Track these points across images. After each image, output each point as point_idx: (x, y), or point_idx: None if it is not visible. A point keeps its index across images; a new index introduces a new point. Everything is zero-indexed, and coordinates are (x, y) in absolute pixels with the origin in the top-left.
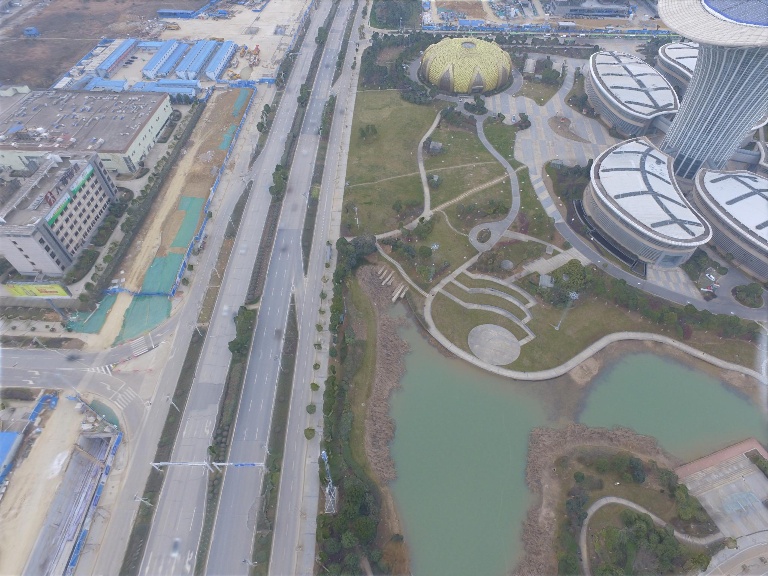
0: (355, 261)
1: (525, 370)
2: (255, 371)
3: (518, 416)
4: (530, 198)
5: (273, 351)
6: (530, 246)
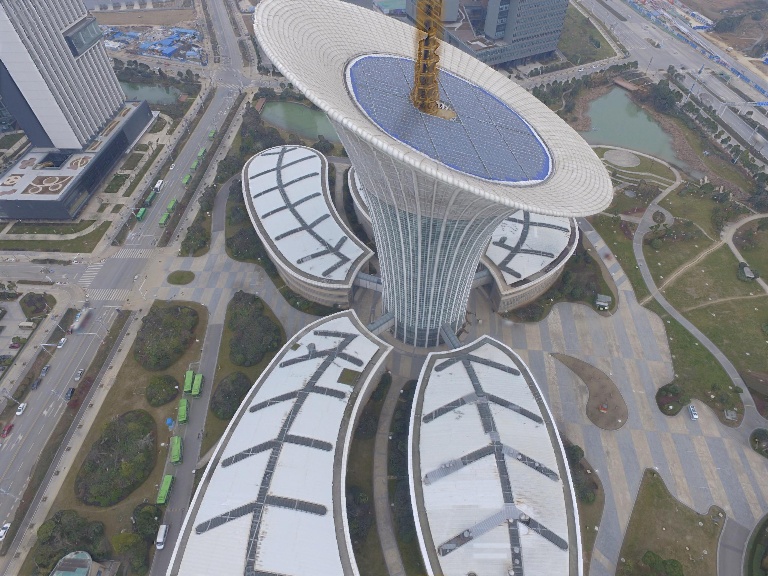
0: (760, 191)
1: (599, 148)
2: (763, 143)
3: (598, 135)
4: (626, 254)
5: (763, 150)
6: (618, 197)
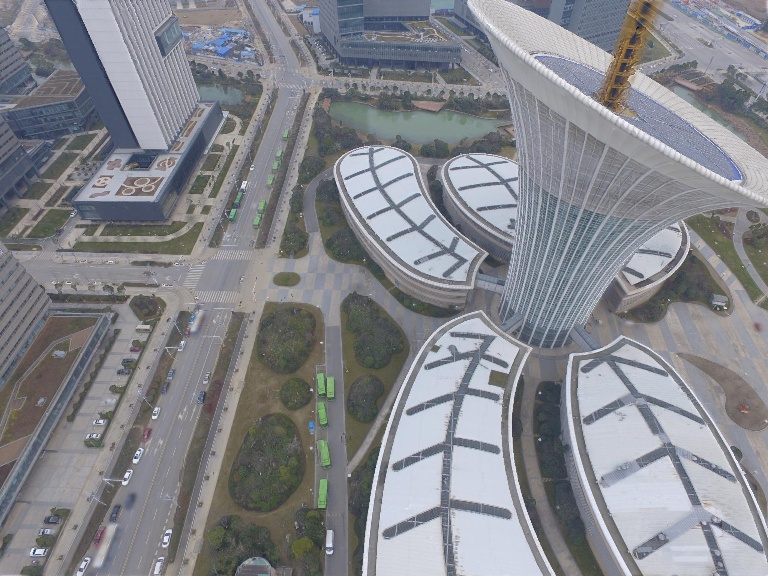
0: None
1: None
2: None
3: None
4: (729, 254)
5: None
6: None
